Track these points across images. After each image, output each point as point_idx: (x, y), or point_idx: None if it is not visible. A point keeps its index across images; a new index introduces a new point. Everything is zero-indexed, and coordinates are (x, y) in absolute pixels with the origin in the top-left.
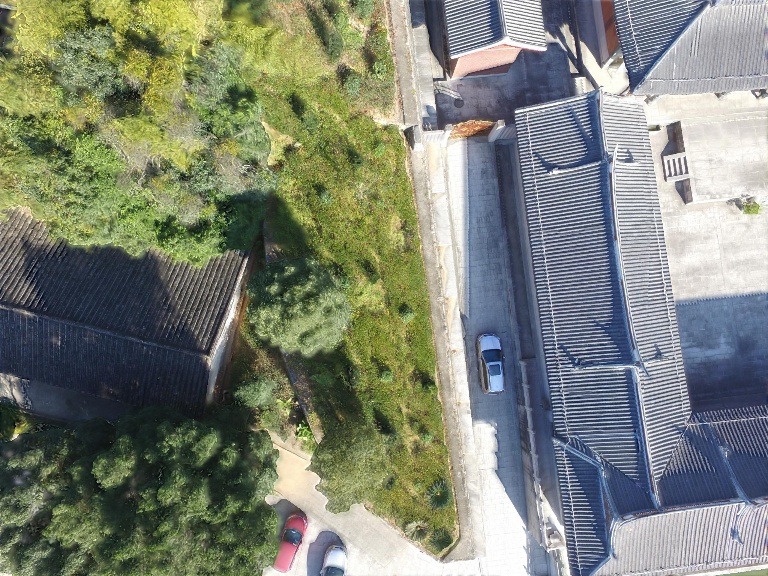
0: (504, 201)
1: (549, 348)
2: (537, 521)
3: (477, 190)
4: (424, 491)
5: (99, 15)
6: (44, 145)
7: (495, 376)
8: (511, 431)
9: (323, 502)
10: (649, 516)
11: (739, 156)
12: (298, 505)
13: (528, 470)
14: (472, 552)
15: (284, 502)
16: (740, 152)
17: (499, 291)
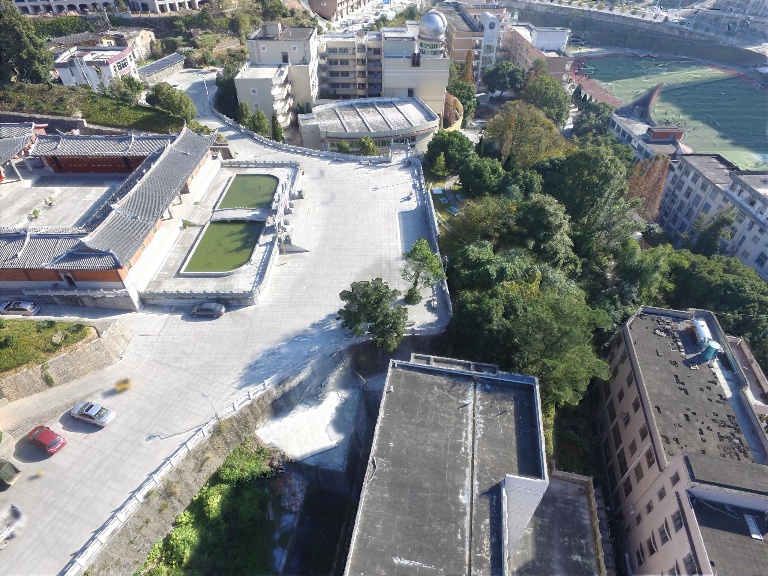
0: None
1: (2, 266)
2: (118, 298)
3: None
4: (36, 329)
5: None
6: None
7: (20, 304)
8: (72, 310)
9: (31, 410)
10: (90, 233)
11: (9, 214)
12: (18, 424)
13: (92, 301)
14: (107, 323)
15: (19, 444)
16: (8, 214)
17: None
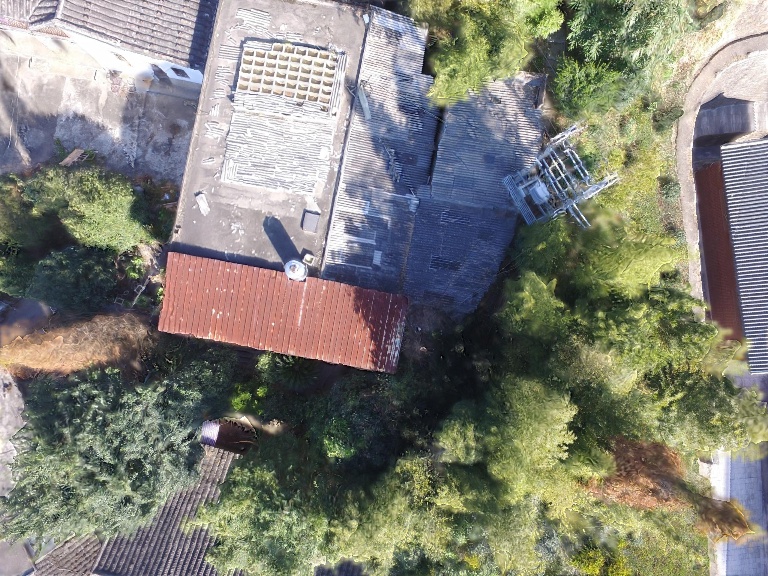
0: (762, 480)
1: None
2: None
3: (739, 473)
4: None
5: (552, 514)
6: (418, 563)
7: None
8: None
9: None
10: None
11: None
12: None
13: None
14: None
15: None
16: None
17: (756, 575)
